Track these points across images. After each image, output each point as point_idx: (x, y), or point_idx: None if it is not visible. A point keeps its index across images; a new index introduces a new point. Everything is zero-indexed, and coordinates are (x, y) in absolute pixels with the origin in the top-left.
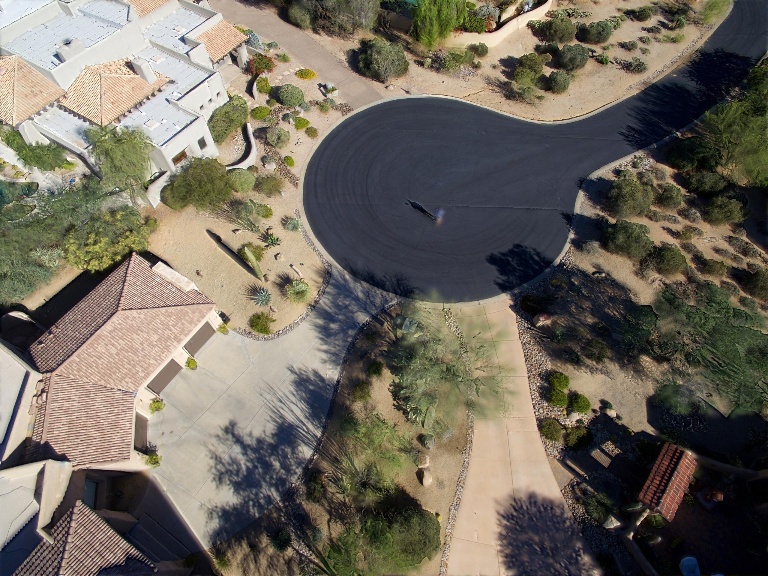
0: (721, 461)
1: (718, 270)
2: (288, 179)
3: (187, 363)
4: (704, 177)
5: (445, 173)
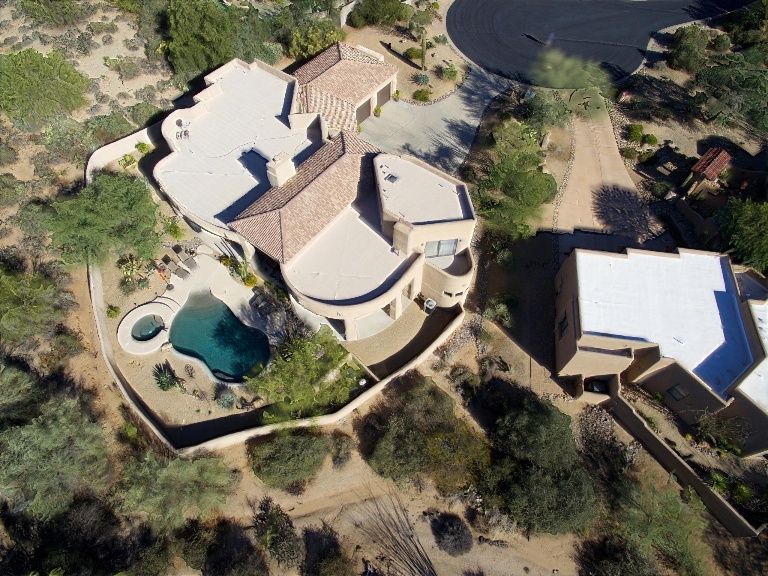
0: (748, 169)
1: (754, 83)
2: (435, 16)
3: (375, 110)
4: (748, 32)
5: (550, 21)
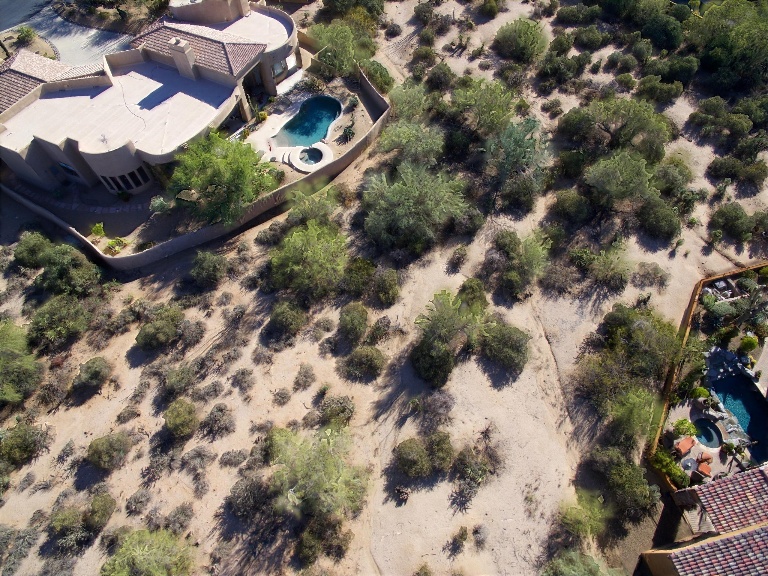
0: None
1: None
2: None
3: None
4: None
5: None
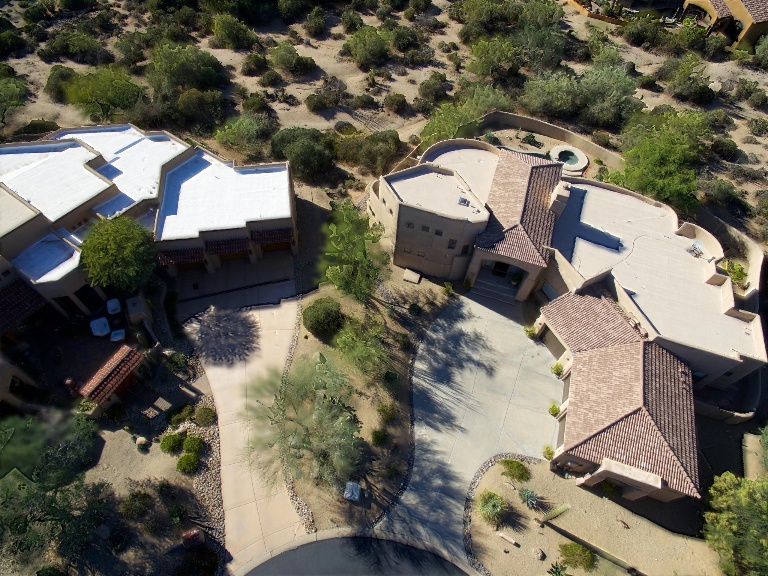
0: (51, 413)
1: None
2: None
3: None
4: None
5: None
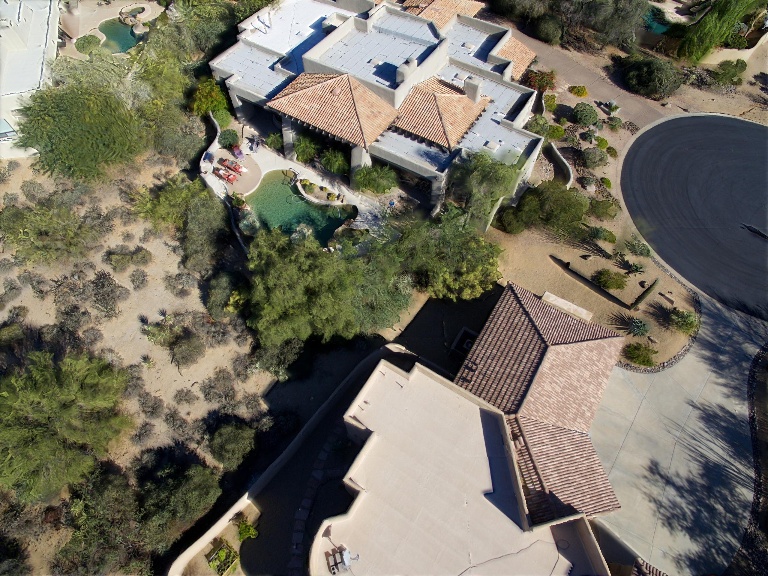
0: None
1: None
2: (612, 202)
3: None
4: None
5: (765, 195)
